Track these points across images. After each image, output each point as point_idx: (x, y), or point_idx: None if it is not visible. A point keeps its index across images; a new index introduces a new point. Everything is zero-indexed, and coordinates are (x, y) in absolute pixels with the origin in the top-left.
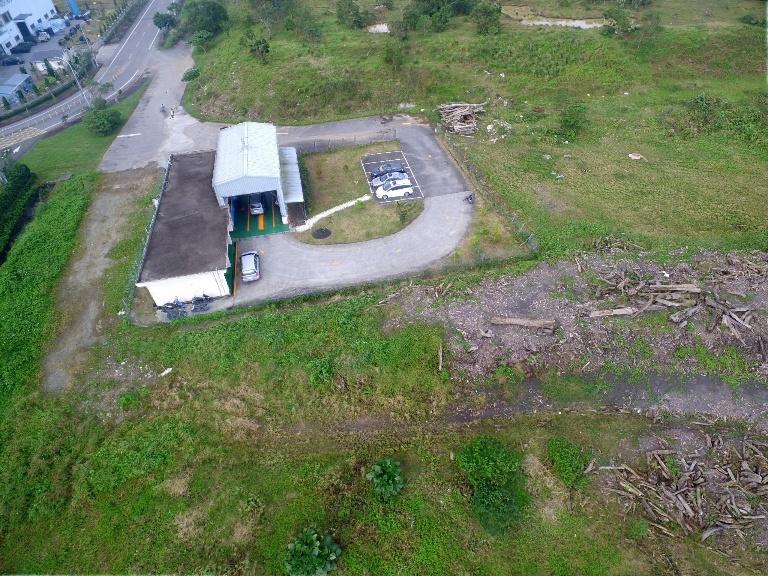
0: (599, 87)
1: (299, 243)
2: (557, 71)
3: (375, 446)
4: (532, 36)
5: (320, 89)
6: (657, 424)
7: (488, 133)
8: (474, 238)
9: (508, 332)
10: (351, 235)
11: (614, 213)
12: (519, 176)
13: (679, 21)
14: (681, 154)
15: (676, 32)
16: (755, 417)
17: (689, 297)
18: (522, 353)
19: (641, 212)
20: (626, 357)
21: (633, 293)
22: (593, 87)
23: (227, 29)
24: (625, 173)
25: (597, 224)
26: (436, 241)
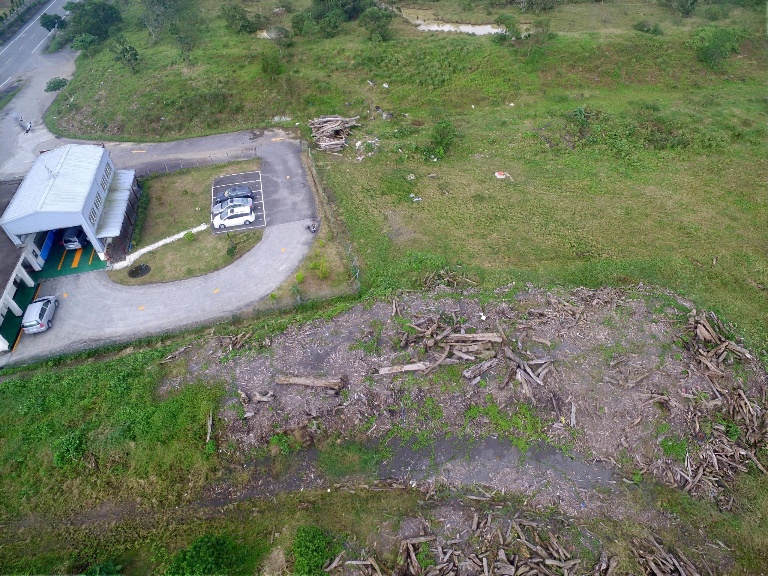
0: (484, 98)
1: (110, 283)
2: (442, 81)
3: (106, 543)
4: (422, 43)
5: (186, 102)
6: (430, 500)
7: (356, 150)
8: (298, 275)
9: (291, 393)
10: (171, 273)
11: (460, 241)
12: (374, 199)
13: (575, 27)
14: (548, 172)
15: (568, 39)
16: (534, 488)
17: (490, 347)
18: (302, 418)
19: (488, 240)
20: (415, 419)
21: (431, 344)
22: (478, 98)
23: (113, 32)
24: (485, 194)
25: (434, 256)
26: (261, 278)
